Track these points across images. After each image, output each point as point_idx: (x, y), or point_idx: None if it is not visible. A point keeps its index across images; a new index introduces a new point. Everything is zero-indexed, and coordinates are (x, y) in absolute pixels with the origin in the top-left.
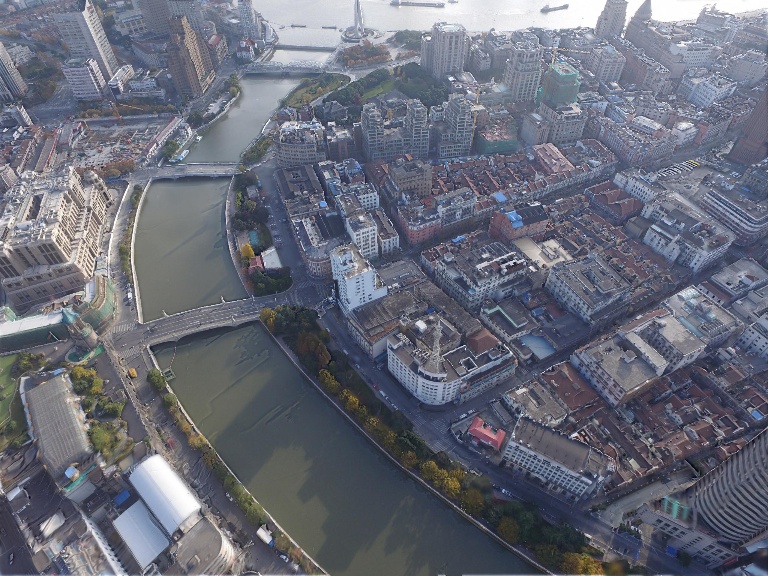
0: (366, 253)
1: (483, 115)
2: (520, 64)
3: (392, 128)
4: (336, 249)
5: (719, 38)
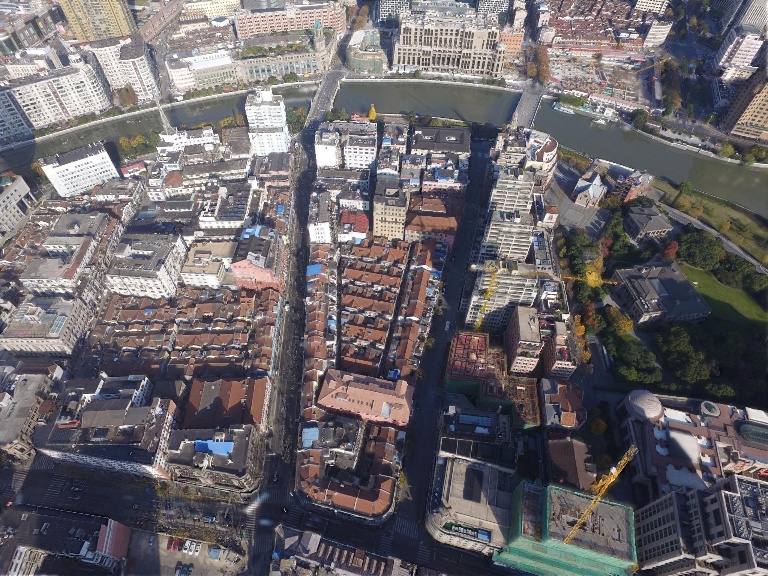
0: None
1: None
2: None
3: None
4: (270, 87)
5: None
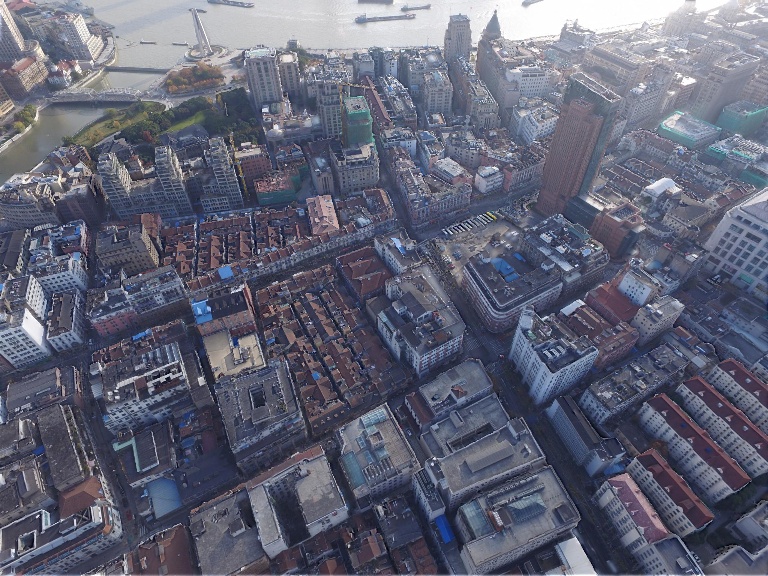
0: (26, 355)
1: (261, 160)
2: (322, 97)
3: (149, 178)
4: None
5: (576, 58)
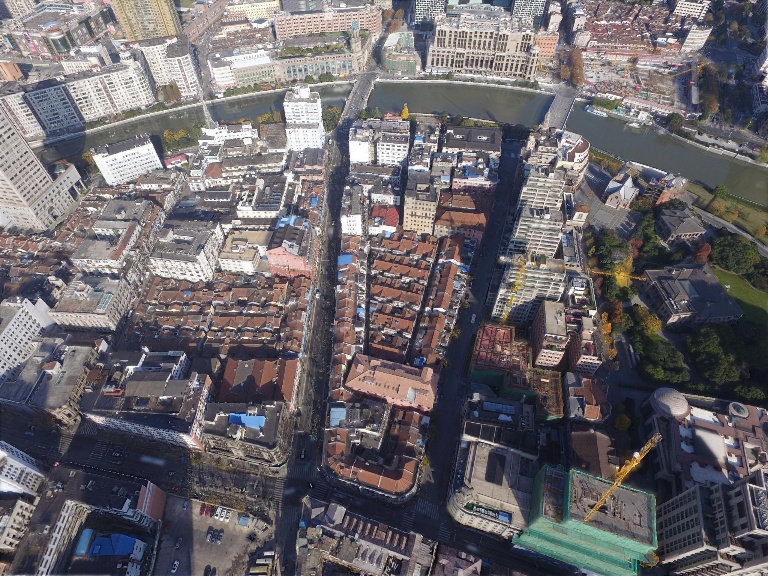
0: None
1: None
2: None
3: None
4: None
5: None
